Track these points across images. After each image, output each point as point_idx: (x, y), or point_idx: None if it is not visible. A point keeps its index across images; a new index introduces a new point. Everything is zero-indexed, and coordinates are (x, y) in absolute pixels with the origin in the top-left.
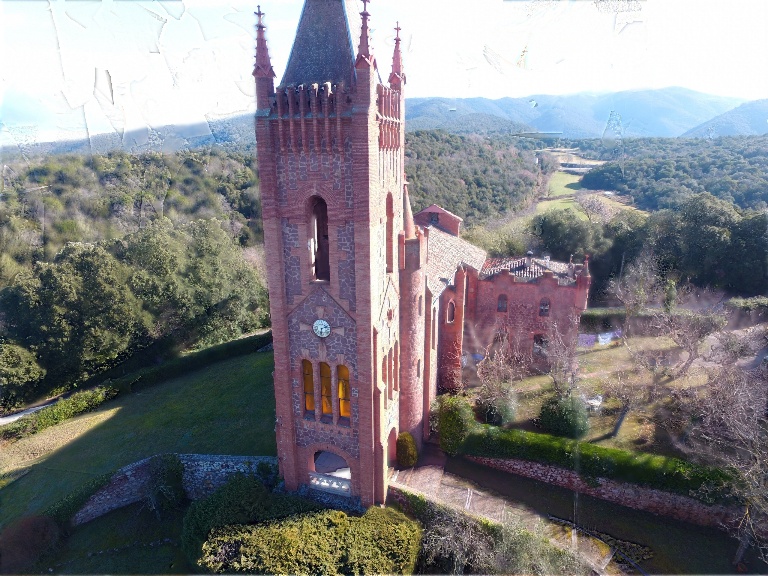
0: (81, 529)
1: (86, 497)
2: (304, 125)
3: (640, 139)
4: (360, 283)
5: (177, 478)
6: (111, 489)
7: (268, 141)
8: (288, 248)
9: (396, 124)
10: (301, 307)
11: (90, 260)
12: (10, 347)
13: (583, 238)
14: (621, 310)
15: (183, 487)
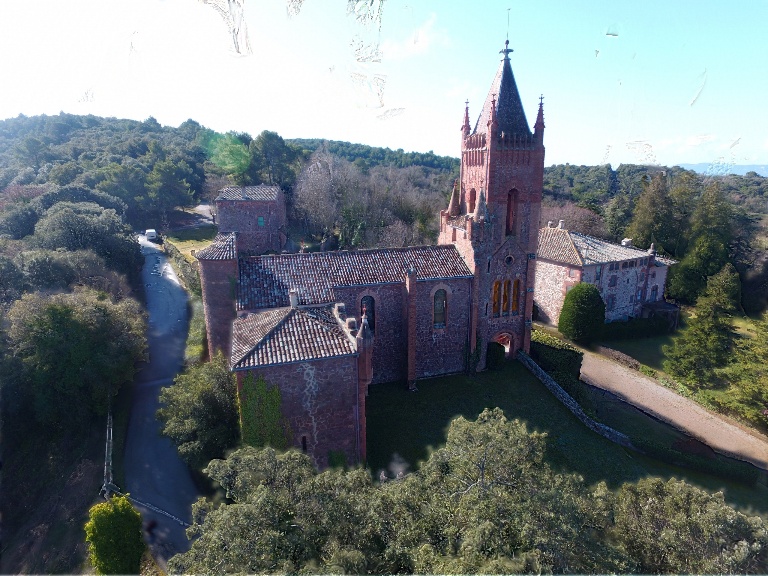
0: None
1: None
2: None
3: None
4: None
5: None
6: None
7: None
8: None
9: None
10: None
11: (743, 516)
12: None
13: None
14: (197, 305)
15: None
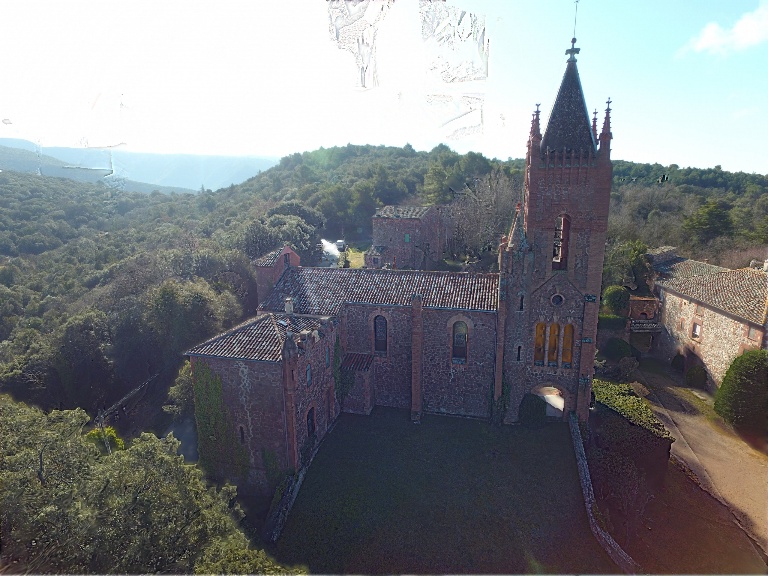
0: None
1: None
2: None
3: (121, 179)
4: None
5: None
6: None
7: None
8: None
9: None
10: None
11: None
12: None
13: (245, 266)
14: None
15: None
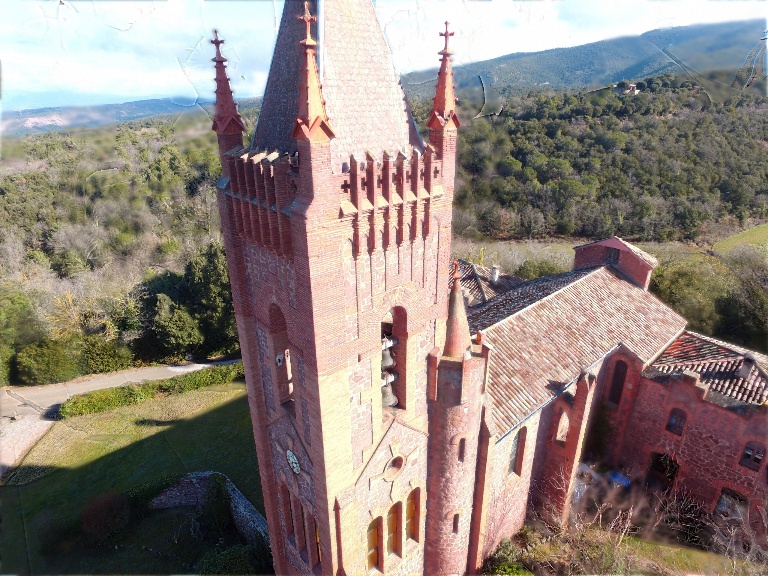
0: (153, 514)
1: (159, 490)
2: (252, 211)
3: None
4: (314, 442)
5: (225, 504)
6: (180, 488)
7: (228, 221)
8: (262, 353)
9: (415, 203)
10: (277, 425)
11: None
12: (180, 313)
13: None
14: None
15: (231, 513)
